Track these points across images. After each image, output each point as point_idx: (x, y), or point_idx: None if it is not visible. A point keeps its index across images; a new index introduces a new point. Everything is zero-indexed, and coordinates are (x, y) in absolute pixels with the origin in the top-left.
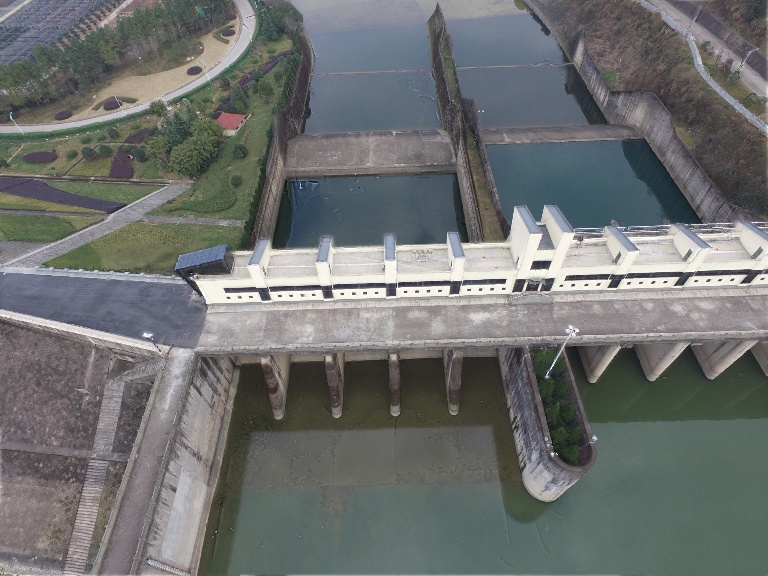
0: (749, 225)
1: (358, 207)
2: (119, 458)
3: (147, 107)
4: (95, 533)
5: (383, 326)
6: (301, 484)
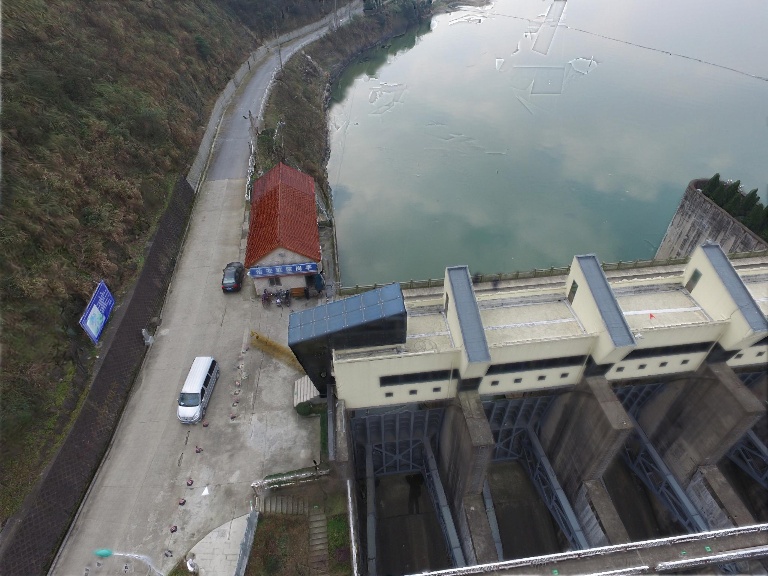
0: (617, 334)
1: None
2: None
3: None
4: None
5: None
6: None
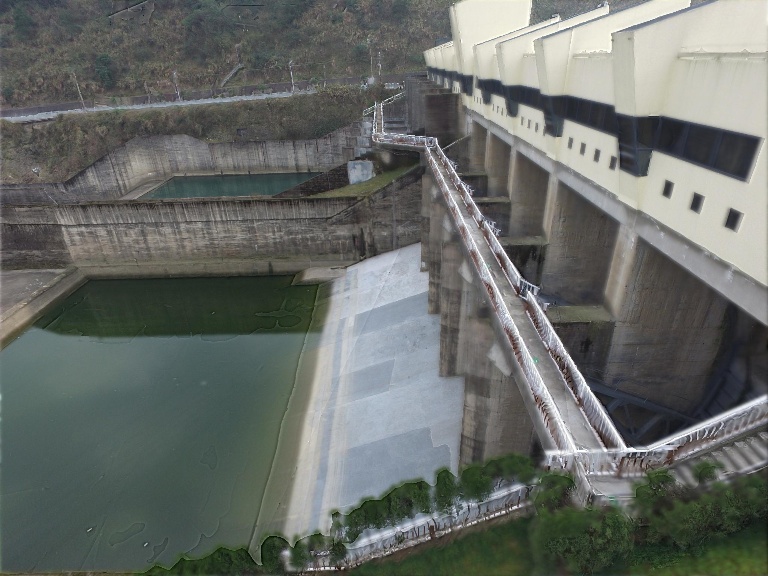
0: None
1: (36, 430)
2: None
3: None
4: None
5: None
6: None
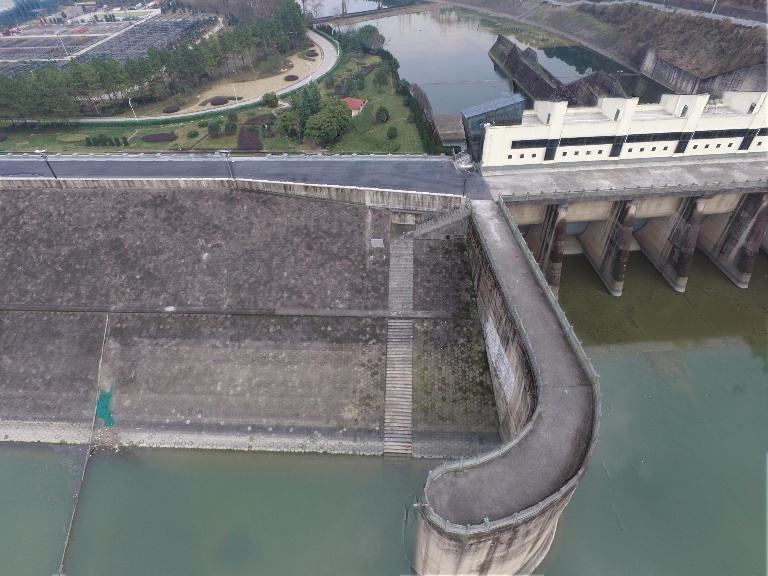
0: None
1: None
2: (425, 314)
3: (257, 100)
4: (415, 396)
5: (683, 177)
6: (617, 352)
